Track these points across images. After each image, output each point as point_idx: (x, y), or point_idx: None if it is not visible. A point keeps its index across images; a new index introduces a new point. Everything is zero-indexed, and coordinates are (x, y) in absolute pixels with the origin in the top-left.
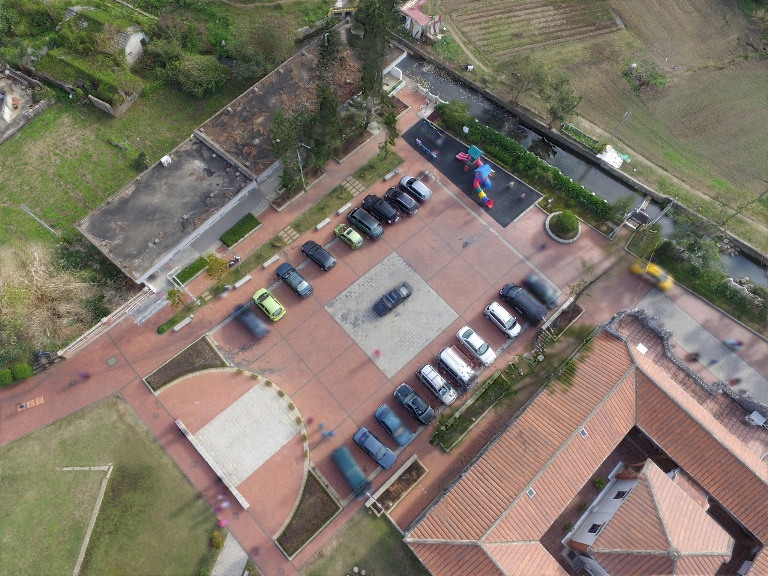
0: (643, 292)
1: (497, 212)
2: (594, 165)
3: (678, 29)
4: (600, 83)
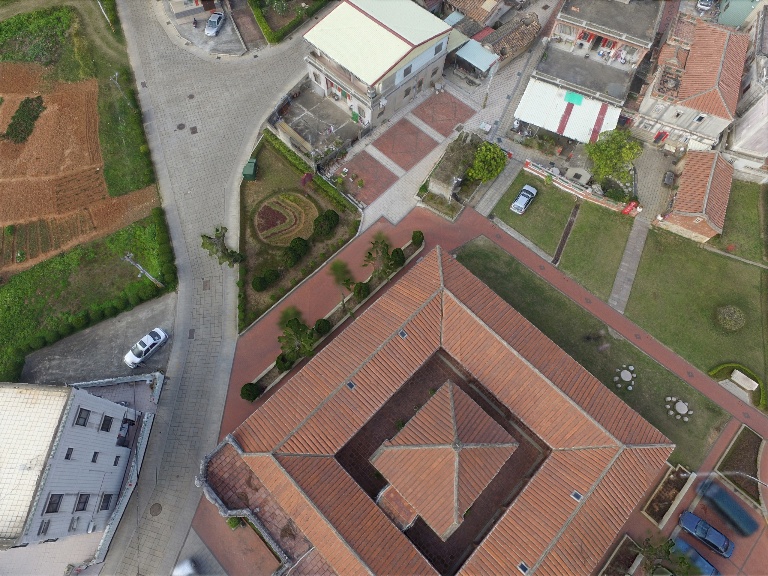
0: None
1: None
2: None
3: None
4: None
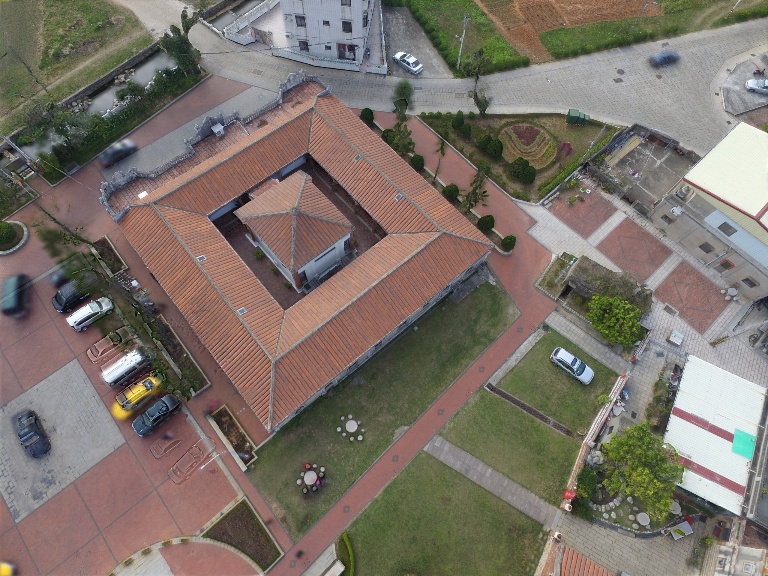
0: None
1: None
2: None
3: None
4: None
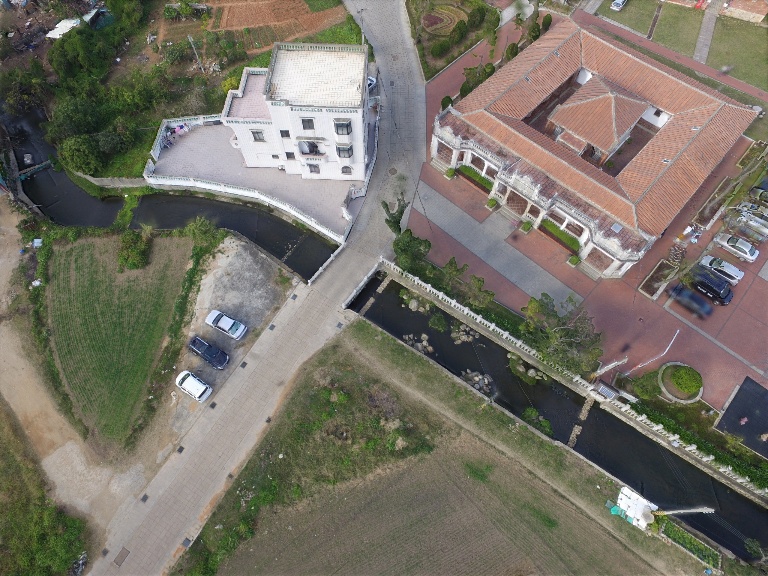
0: None
1: (764, 397)
2: None
3: None
4: None
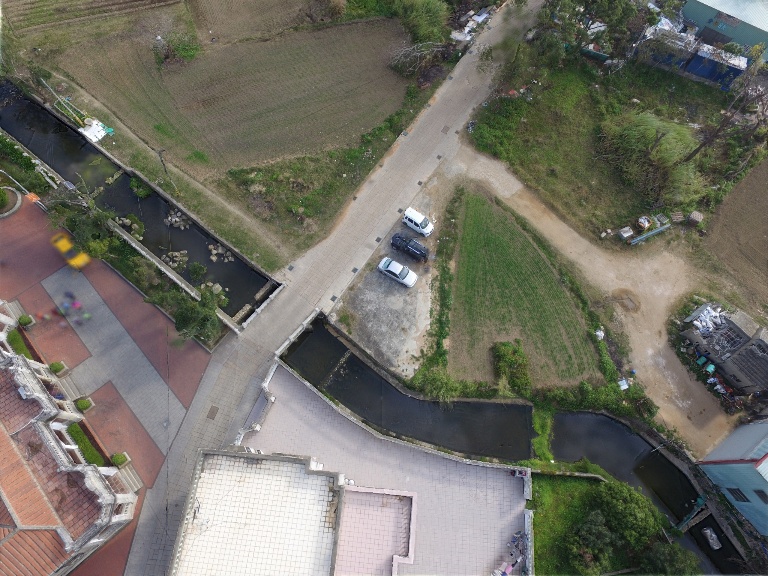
0: (57, 267)
1: None
2: (84, 140)
3: (239, 1)
4: (123, 57)
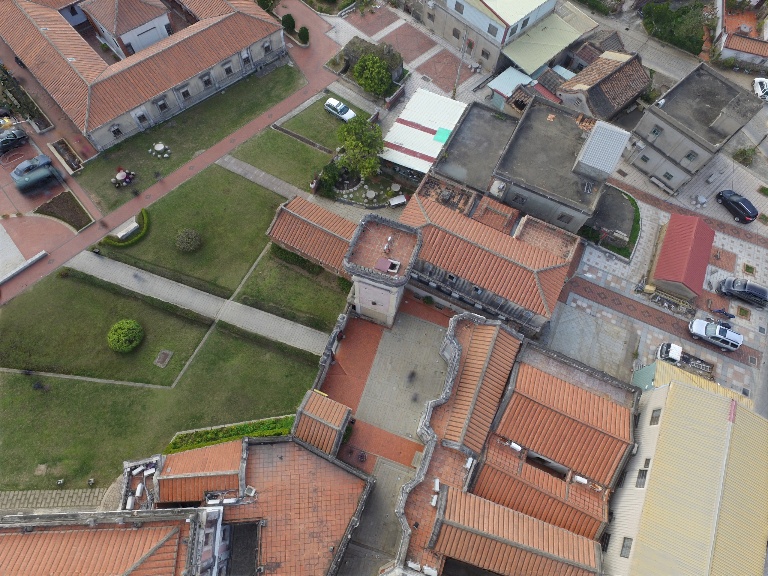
0: None
1: None
2: None
3: None
4: None
